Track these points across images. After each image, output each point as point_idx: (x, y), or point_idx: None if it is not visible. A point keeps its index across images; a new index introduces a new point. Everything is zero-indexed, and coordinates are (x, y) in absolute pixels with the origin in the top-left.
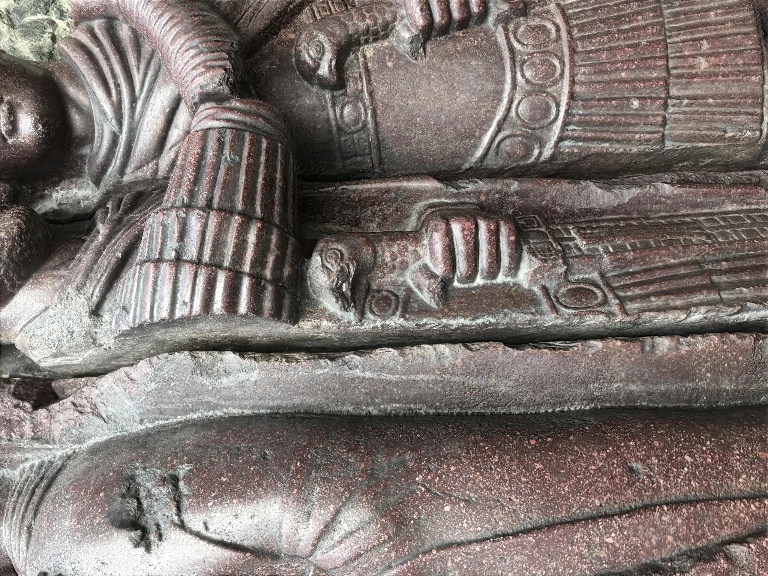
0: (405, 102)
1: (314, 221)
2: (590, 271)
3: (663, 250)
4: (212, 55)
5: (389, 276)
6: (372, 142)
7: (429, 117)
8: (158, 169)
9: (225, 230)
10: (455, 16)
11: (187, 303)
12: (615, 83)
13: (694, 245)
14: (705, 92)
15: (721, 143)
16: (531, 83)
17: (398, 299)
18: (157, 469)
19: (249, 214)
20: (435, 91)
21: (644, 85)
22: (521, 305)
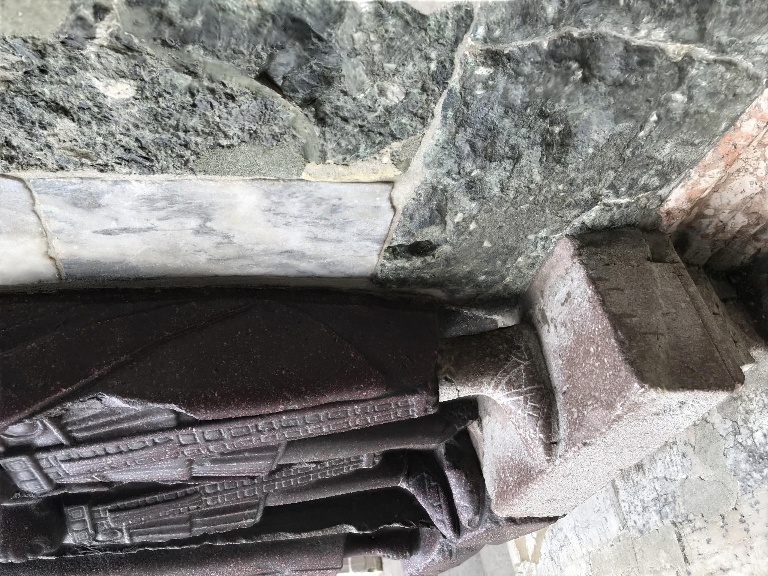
0: None
1: None
2: None
3: None
4: None
5: None
6: None
7: None
8: None
9: None
10: None
11: None
12: None
13: None
14: None
15: None
16: None
17: None
18: None
19: None
20: None
21: None
22: None
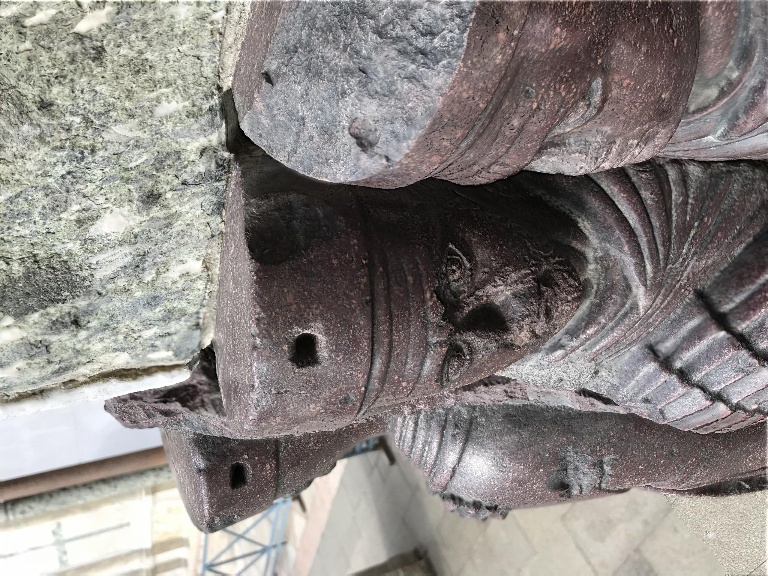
0: None
1: None
2: None
3: None
4: None
5: None
6: None
7: None
8: None
9: None
10: None
11: None
12: None
13: None
14: None
15: None
16: None
17: None
18: (588, 456)
19: None
20: None
21: None
22: None
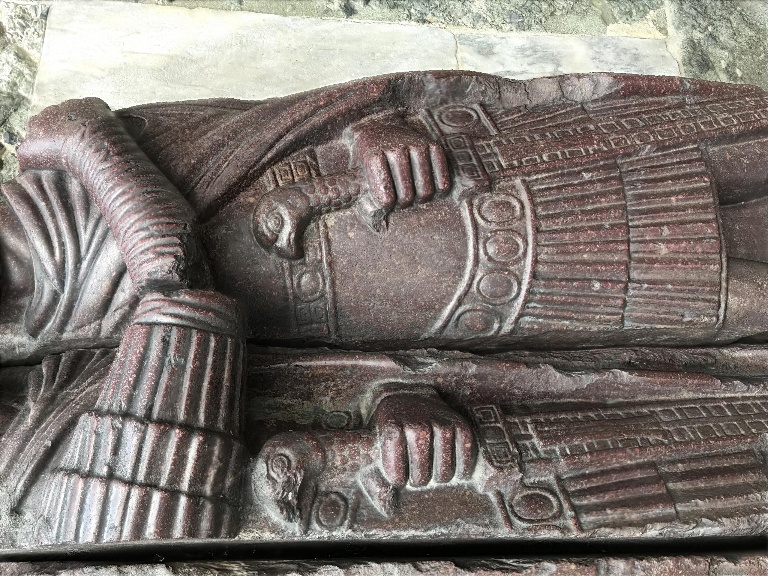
0: (365, 273)
1: (264, 395)
2: (546, 474)
3: (620, 453)
4: (163, 240)
5: (339, 476)
6: (329, 311)
7: (389, 289)
8: (101, 329)
9: (164, 445)
10: (419, 193)
11: (117, 527)
12: (577, 265)
13: (651, 447)
14: (665, 277)
15: (679, 326)
16: (493, 261)
17: (347, 504)
18: None
19: (191, 423)
20: (396, 264)
21: (605, 269)
22: (475, 514)
